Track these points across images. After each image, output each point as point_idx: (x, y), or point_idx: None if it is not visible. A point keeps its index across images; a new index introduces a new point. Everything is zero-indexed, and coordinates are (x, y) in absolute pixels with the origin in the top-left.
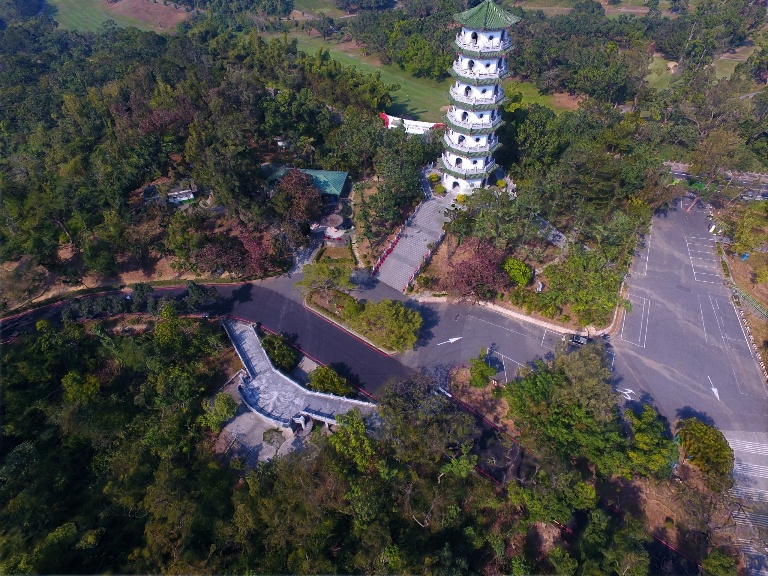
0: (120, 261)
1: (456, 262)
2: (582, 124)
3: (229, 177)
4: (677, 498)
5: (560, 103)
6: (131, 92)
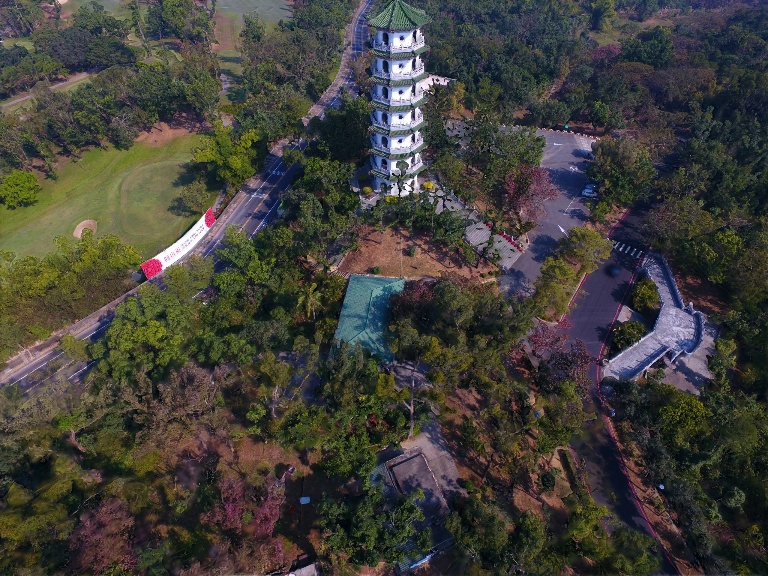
0: (571, 569)
1: None
2: None
3: (519, 307)
4: (658, 153)
5: (159, 141)
6: (190, 574)
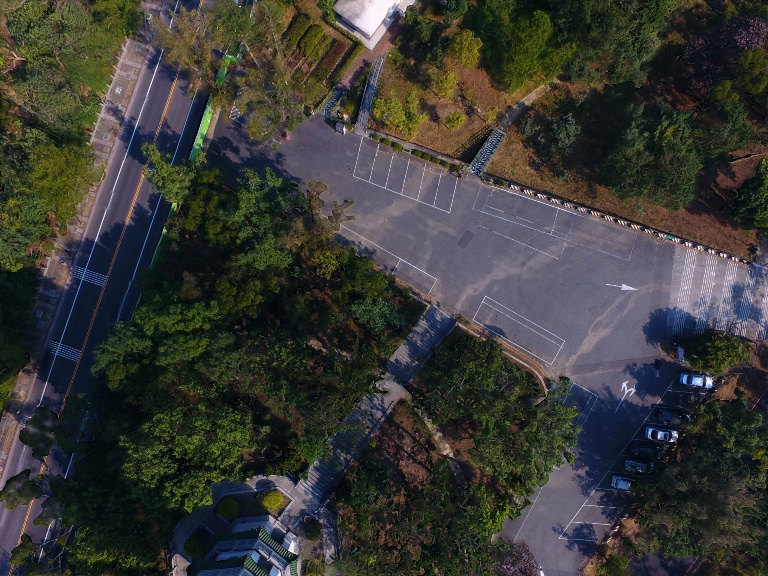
0: None
1: (421, 571)
2: (5, 234)
3: None
4: None
5: None
6: None
